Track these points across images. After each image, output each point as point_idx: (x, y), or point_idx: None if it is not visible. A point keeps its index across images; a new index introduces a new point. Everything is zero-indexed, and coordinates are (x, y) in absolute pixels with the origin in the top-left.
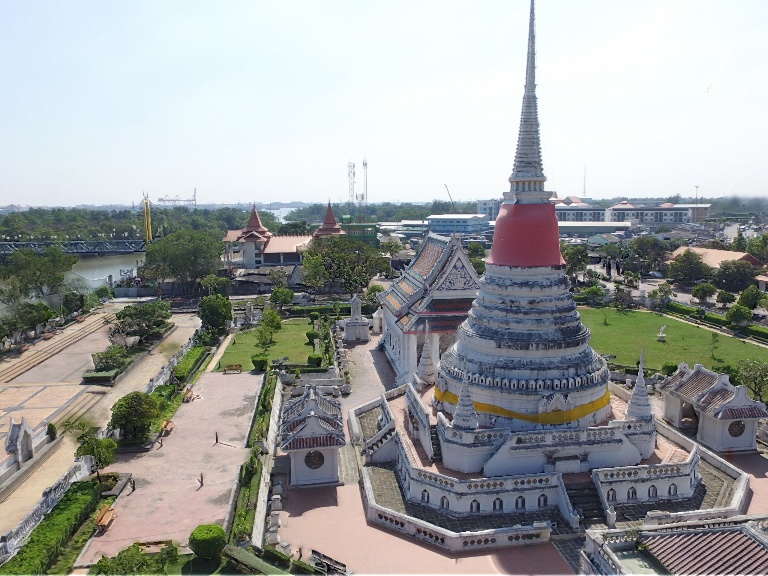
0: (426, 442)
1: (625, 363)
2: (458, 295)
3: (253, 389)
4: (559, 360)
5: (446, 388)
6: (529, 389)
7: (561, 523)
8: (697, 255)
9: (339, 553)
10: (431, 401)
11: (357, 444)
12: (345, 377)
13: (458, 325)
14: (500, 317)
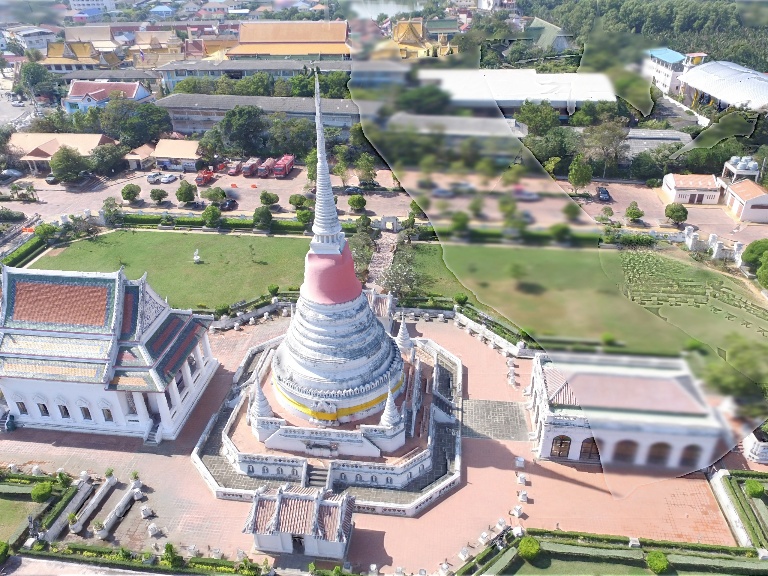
0: (366, 450)
1: (232, 300)
2: (155, 326)
3: (81, 573)
4: (386, 342)
5: (336, 408)
6: (394, 371)
7: (448, 426)
8: (74, 150)
9: (448, 540)
10: (320, 425)
11: None
12: (134, 475)
13: (183, 353)
14: (357, 338)
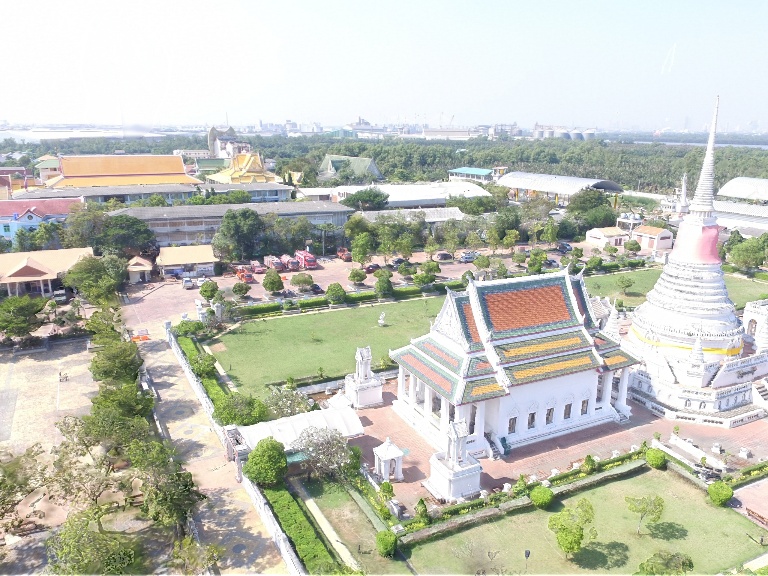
0: None
1: None
2: None
3: None
4: None
5: None
6: None
7: None
8: (98, 260)
9: None
10: (735, 359)
11: (767, 412)
12: None
13: None
14: None
